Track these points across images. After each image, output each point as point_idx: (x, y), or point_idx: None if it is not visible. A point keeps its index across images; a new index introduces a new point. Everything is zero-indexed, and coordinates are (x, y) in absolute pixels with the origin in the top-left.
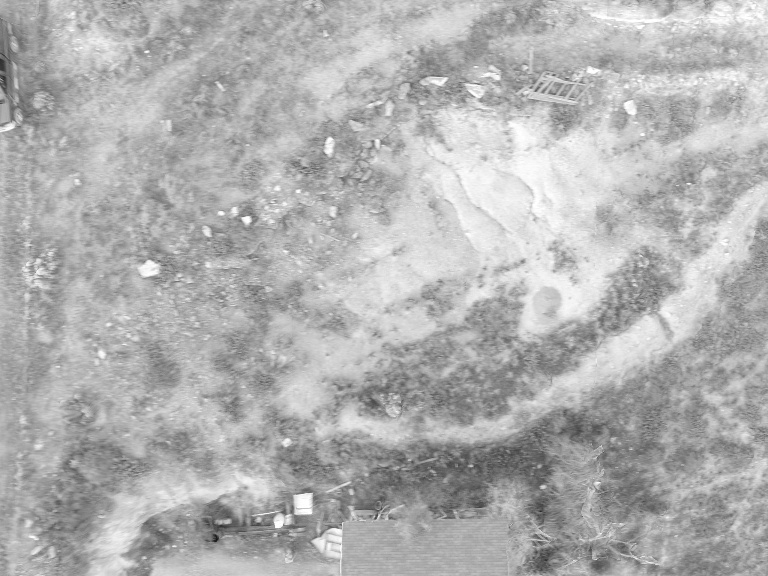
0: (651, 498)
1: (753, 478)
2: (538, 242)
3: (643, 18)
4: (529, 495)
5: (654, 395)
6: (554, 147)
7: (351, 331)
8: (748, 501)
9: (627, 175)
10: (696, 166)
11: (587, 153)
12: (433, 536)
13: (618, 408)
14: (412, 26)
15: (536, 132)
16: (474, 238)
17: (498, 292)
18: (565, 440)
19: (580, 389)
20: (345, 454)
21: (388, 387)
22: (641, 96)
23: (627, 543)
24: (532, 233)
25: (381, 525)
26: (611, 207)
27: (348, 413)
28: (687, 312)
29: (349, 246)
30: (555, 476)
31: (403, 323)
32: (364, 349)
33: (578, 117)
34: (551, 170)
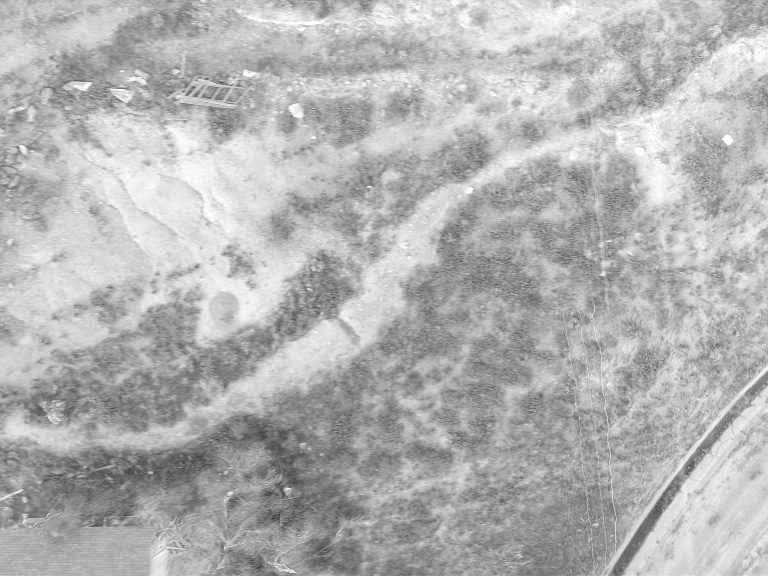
0: (347, 504)
1: (456, 483)
2: (212, 247)
3: (300, 20)
4: (214, 502)
5: (342, 400)
6: (218, 151)
7: (17, 338)
8: (452, 506)
9: (301, 179)
10: (375, 169)
11: (256, 157)
12: (77, 544)
13: (305, 413)
14: (57, 31)
15: (196, 136)
16: (143, 243)
17: (173, 297)
18: (242, 446)
19: (260, 395)
20: (12, 462)
21: (57, 394)
22: (307, 99)
23: (280, 550)
24: (206, 238)
25: (26, 534)
26: (287, 211)
27: (14, 420)
28: (370, 316)
29: (5, 253)
30: (240, 482)
31: (74, 329)
32: (33, 356)
33: (240, 121)
34: (217, 174)
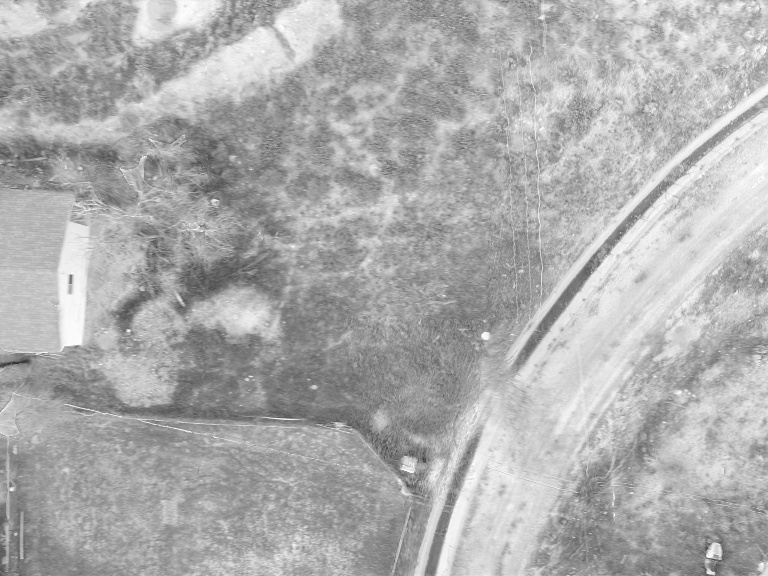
0: (274, 223)
1: (383, 214)
2: None
3: None
4: None
5: (274, 114)
6: None
7: None
8: (379, 238)
9: None
10: None
11: None
12: None
13: (237, 125)
14: None
15: None
16: None
17: None
18: None
19: (192, 98)
20: None
21: None
22: None
23: None
24: None
25: None
26: None
27: None
28: (305, 29)
29: None
30: (168, 187)
31: (12, 17)
32: None
33: None
34: None
